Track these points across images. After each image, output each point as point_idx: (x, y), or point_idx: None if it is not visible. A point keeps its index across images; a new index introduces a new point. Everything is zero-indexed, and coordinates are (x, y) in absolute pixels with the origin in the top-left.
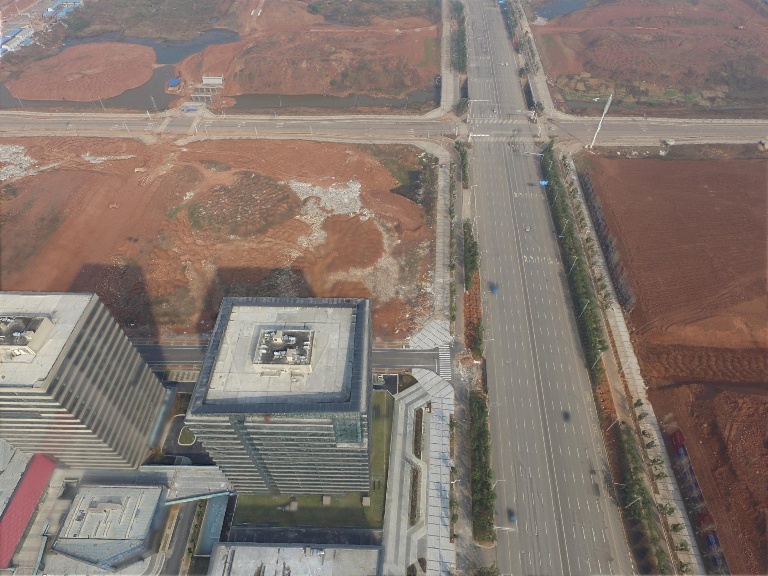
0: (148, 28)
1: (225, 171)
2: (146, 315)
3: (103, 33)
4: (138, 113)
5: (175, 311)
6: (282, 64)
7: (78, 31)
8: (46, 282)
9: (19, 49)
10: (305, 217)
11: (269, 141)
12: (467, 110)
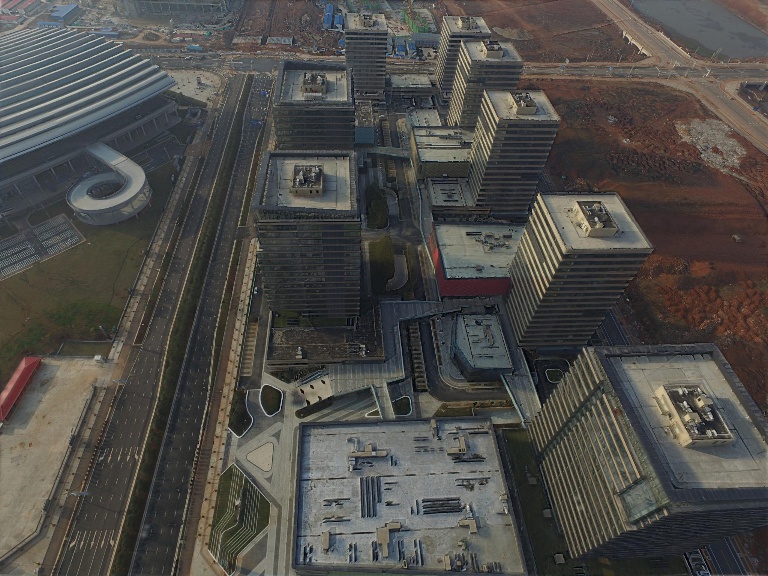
0: None
1: None
2: (643, 306)
3: None
4: None
5: (660, 327)
6: None
7: None
8: None
9: None
10: None
11: None
12: None
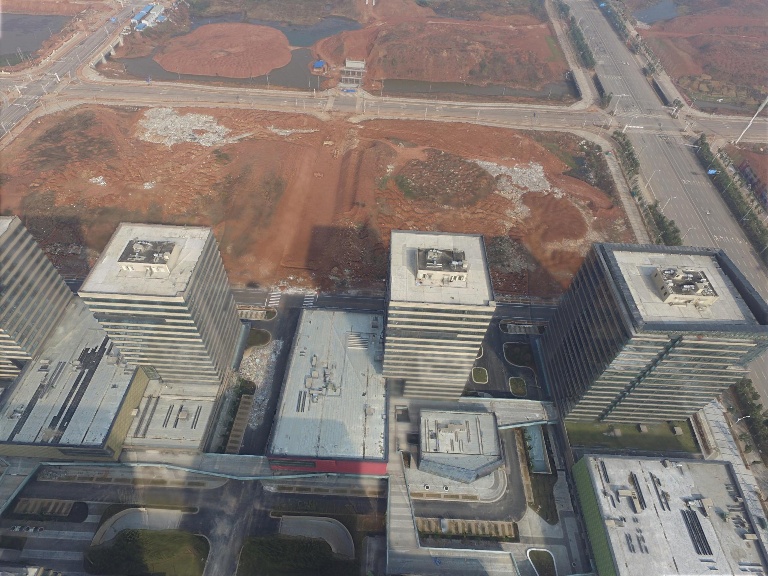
0: (268, 11)
1: (414, 148)
2: None
3: (226, 14)
4: (301, 91)
5: None
6: (424, 52)
7: (201, 11)
8: (289, 239)
9: (156, 25)
10: (503, 192)
11: (438, 123)
12: (609, 104)
